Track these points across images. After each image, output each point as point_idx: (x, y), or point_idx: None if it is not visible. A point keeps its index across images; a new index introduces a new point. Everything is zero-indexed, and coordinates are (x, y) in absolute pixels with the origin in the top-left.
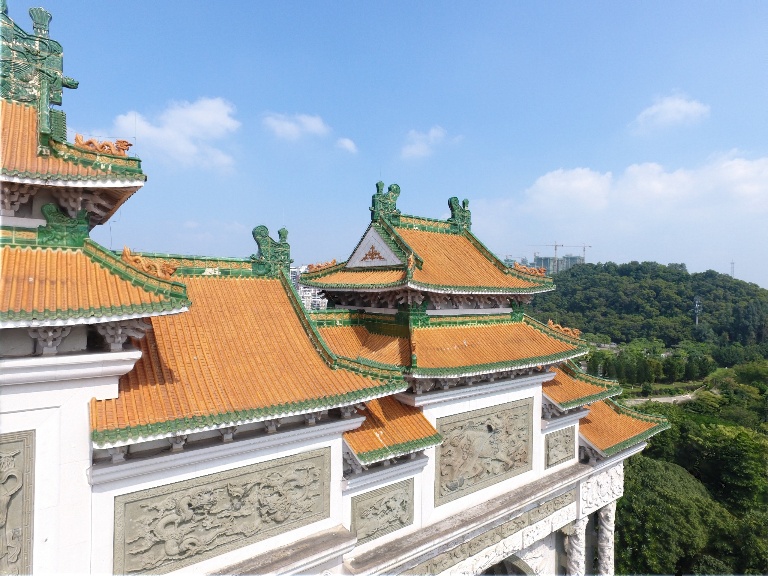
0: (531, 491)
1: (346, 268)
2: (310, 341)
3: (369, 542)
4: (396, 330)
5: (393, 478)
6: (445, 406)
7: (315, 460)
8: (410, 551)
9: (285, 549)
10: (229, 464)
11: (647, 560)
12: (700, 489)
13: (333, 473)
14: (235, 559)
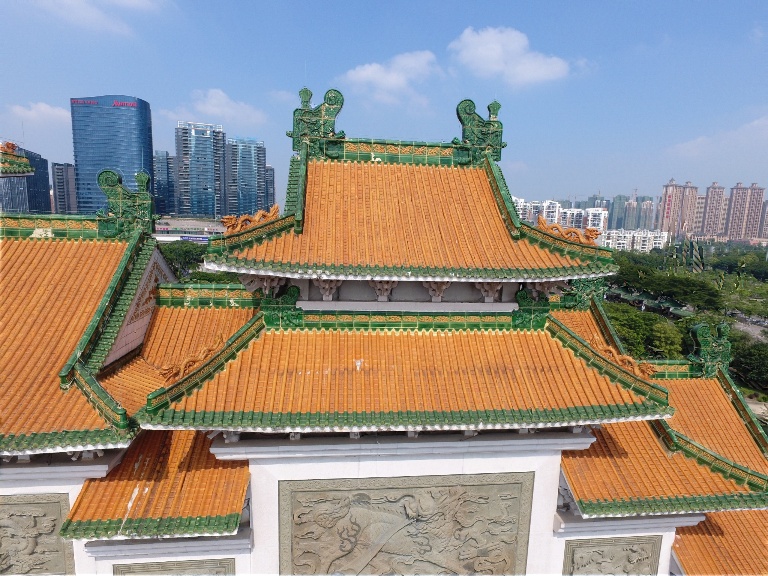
0: None
1: None
2: None
3: None
4: None
5: (192, 552)
6: (300, 464)
7: (46, 506)
8: None
9: None
10: None
11: None
12: None
13: None
14: None
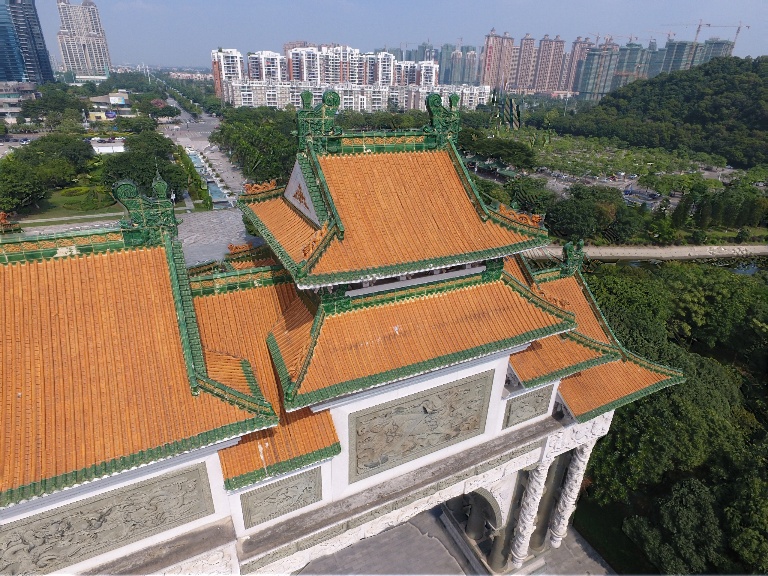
0: (474, 459)
1: (284, 197)
2: (181, 347)
3: (268, 521)
4: (312, 309)
5: None
6: (362, 400)
7: (187, 474)
8: (307, 534)
9: (163, 546)
10: (75, 497)
11: (631, 467)
12: (732, 392)
13: (212, 481)
14: (108, 559)
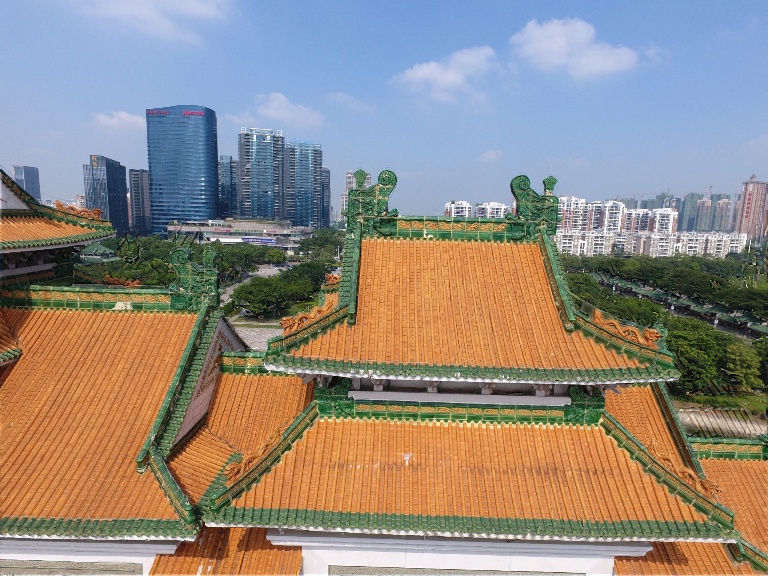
0: None
1: None
2: None
3: None
4: None
5: None
6: (349, 551)
7: (123, 573)
8: None
9: None
10: (11, 554)
11: None
12: None
13: None
14: None
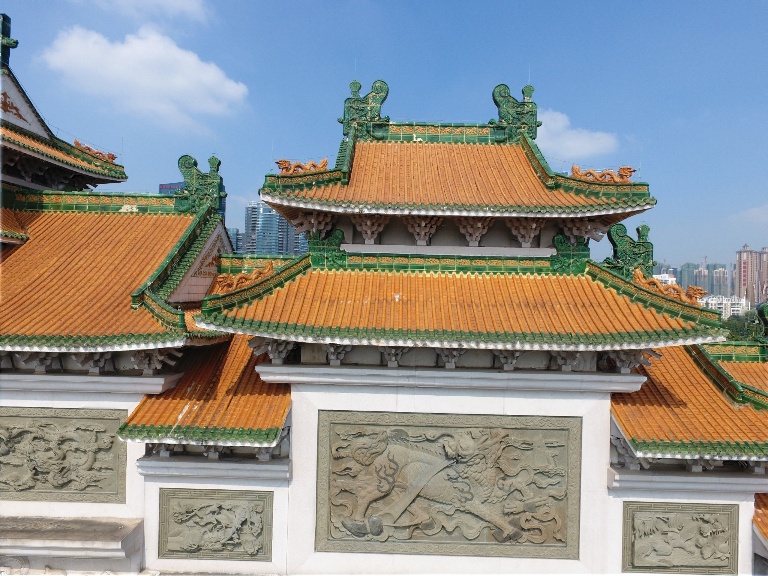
0: None
1: None
2: None
3: (190, 560)
4: None
5: (233, 481)
6: (339, 393)
7: (108, 423)
8: None
9: (55, 522)
10: None
11: None
12: None
13: (131, 446)
14: (1, 511)
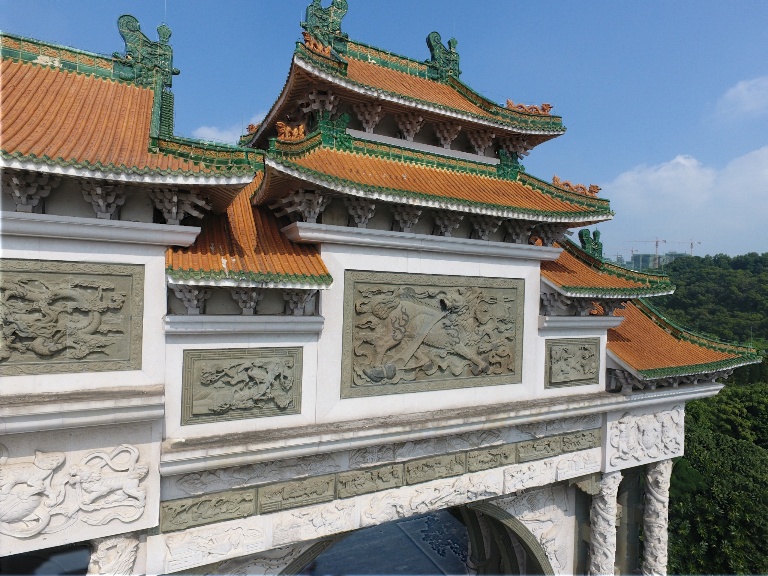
0: (512, 407)
1: None
2: (148, 135)
3: (217, 423)
4: None
5: (264, 339)
6: (362, 255)
7: (116, 280)
8: (274, 441)
9: (48, 396)
10: None
11: (729, 561)
12: None
13: (148, 306)
14: None
